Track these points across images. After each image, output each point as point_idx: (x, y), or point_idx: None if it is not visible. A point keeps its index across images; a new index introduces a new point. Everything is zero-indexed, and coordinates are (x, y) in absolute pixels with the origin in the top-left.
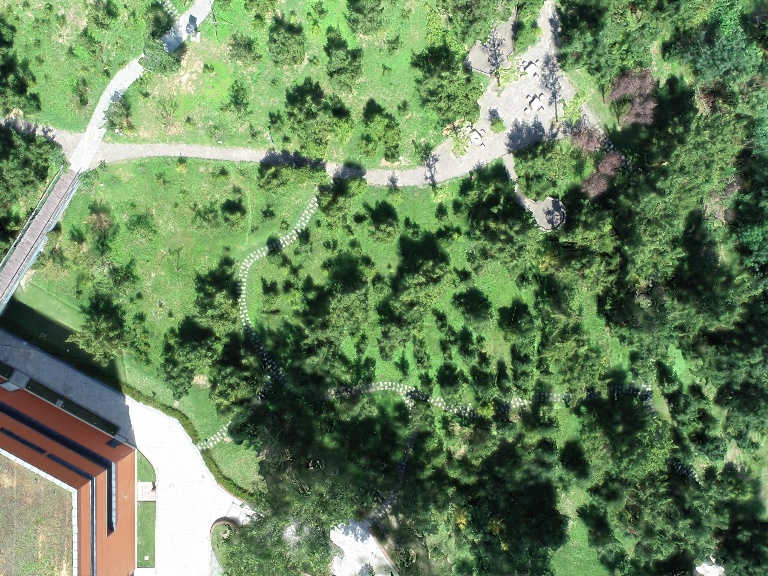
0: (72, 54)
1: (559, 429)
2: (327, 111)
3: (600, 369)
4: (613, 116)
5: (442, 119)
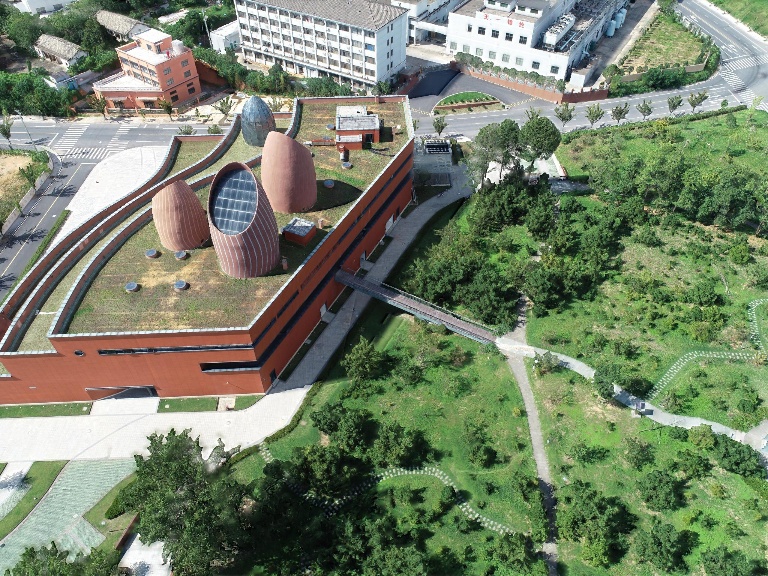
0: (587, 334)
1: None
2: (609, 539)
3: None
4: None
5: None
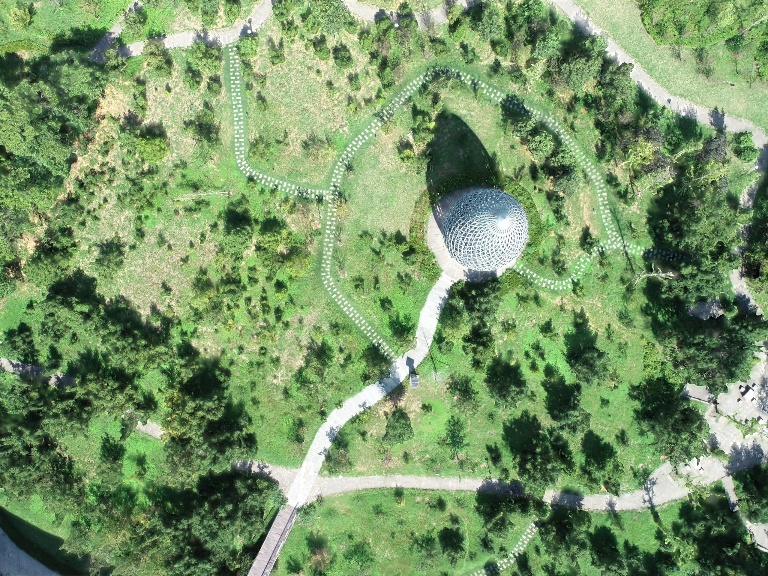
0: (287, 394)
1: None
2: (545, 443)
3: None
4: None
5: None
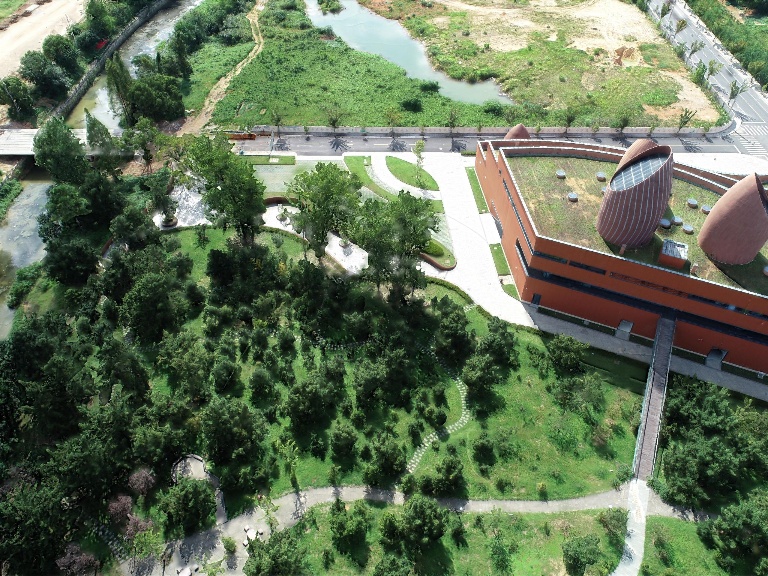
0: None
1: (205, 310)
2: (408, 551)
3: (166, 344)
4: None
5: None
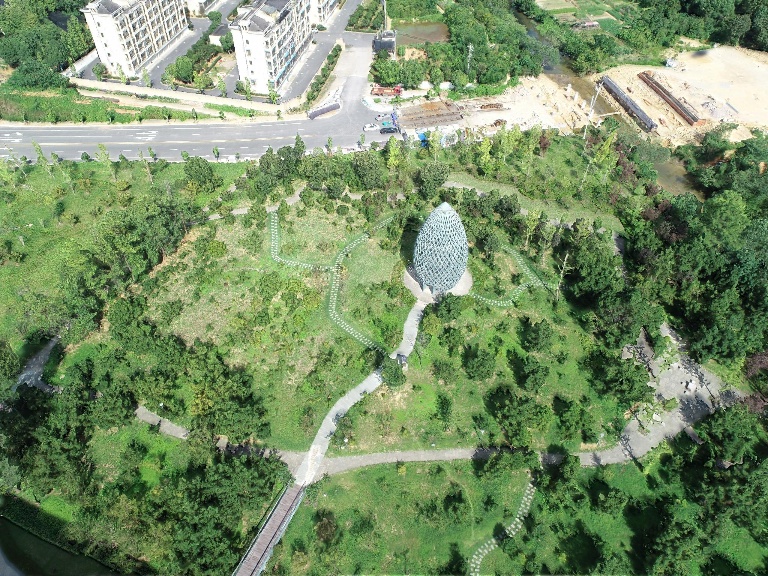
0: None
1: None
2: None
3: None
4: (756, 392)
5: (620, 406)
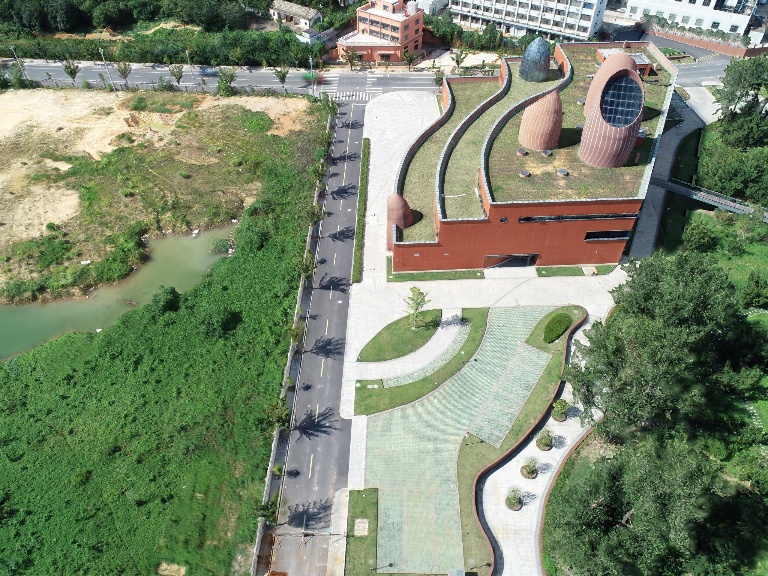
0: None
1: None
2: None
3: None
4: None
5: None
